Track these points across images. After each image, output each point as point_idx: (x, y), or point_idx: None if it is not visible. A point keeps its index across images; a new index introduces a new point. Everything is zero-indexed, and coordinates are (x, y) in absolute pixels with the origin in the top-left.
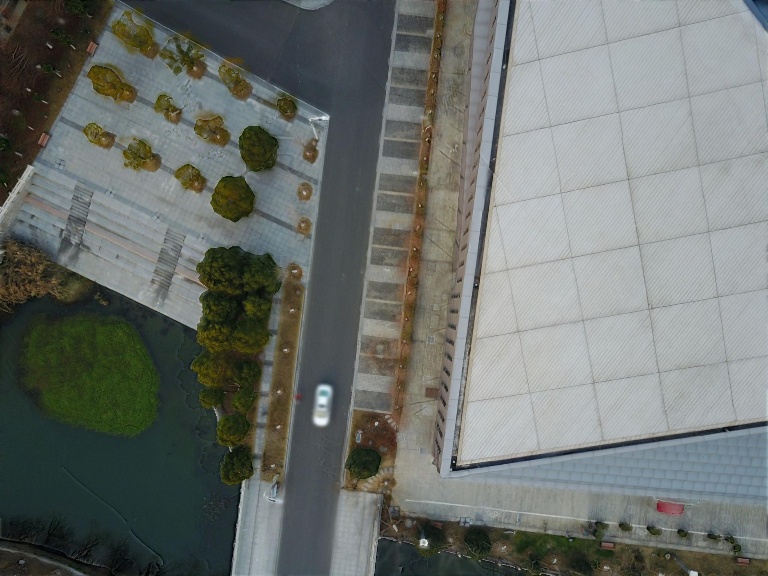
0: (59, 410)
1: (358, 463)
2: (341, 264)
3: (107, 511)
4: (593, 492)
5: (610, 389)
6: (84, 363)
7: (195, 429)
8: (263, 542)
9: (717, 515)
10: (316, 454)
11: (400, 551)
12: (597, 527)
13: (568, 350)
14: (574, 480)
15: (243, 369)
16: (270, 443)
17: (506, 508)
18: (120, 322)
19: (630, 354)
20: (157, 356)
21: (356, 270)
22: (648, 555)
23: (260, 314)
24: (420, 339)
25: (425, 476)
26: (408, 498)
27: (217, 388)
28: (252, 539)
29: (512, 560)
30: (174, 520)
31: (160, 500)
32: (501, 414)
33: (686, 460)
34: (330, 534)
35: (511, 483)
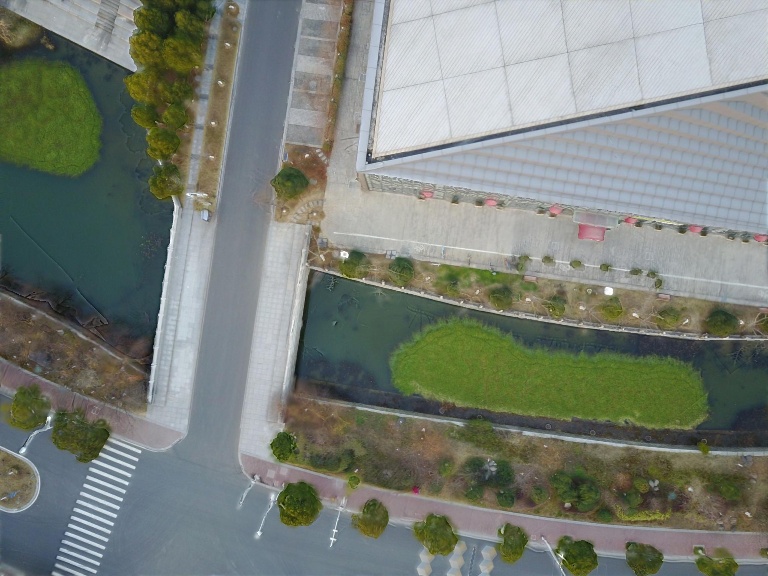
0: (5, 149)
1: (282, 175)
2: (277, 2)
3: (55, 269)
4: (518, 228)
5: (520, 72)
6: (29, 104)
7: (135, 171)
8: (194, 270)
9: (640, 253)
10: (248, 186)
11: (335, 309)
12: (520, 260)
13: (480, 33)
14: (488, 180)
15: (174, 83)
16: (203, 174)
17: (432, 242)
18: (65, 66)
19: (540, 34)
20: (100, 100)
21: (292, 8)
22: (570, 290)
23: (191, 29)
24: (353, 77)
25: (353, 209)
26: (336, 231)
27: (149, 105)
28: (184, 266)
29: (436, 291)
30: (116, 269)
31: (102, 249)
32: (415, 103)
33: (598, 158)
34: (259, 263)
35: (426, 181)
